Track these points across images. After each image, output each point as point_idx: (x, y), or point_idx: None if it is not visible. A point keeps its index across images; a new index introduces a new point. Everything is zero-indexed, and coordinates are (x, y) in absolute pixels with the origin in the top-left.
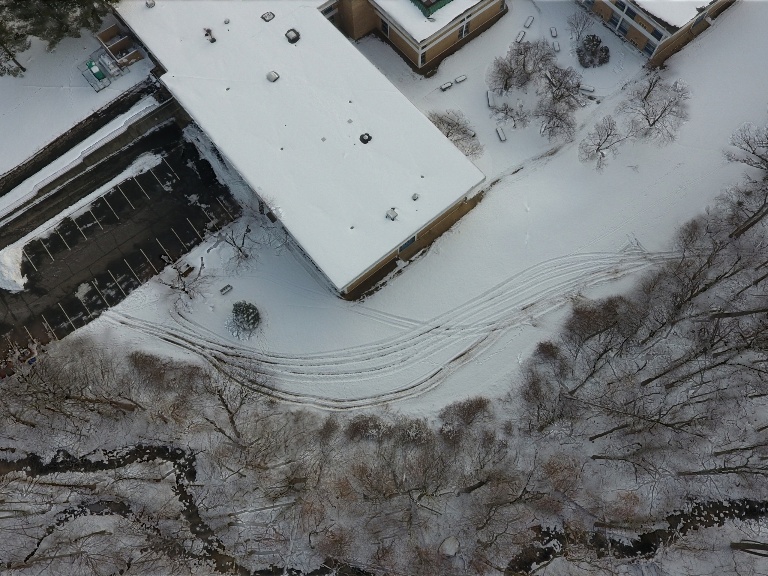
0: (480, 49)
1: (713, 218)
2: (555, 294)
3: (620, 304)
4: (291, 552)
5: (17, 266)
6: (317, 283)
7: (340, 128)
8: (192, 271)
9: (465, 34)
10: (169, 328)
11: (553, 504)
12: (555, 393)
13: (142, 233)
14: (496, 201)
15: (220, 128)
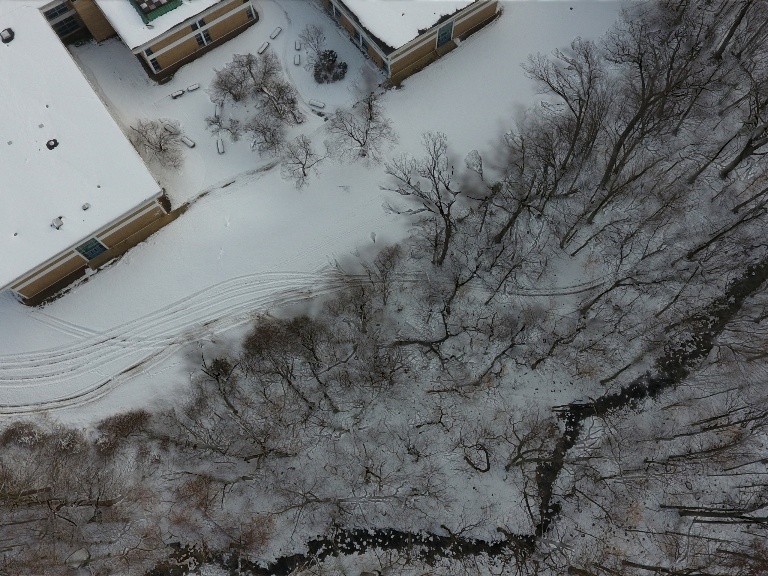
0: (220, 58)
1: (415, 244)
2: (241, 311)
3: (304, 325)
4: None
5: None
6: None
7: (29, 132)
8: None
9: (208, 42)
10: None
11: (189, 522)
12: (217, 411)
13: None
14: (199, 214)
15: None
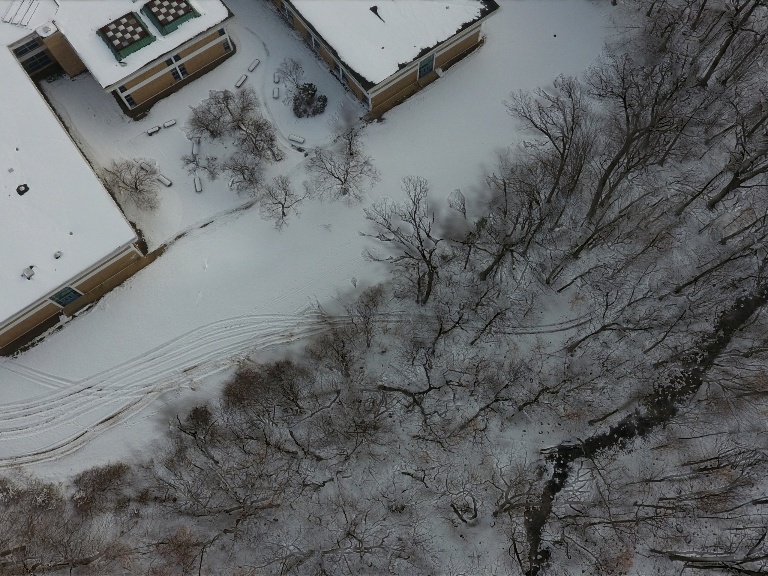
0: (197, 92)
1: (398, 283)
2: (221, 357)
3: (286, 370)
4: None
5: None
6: None
7: None
8: None
9: (185, 75)
10: None
11: None
12: (197, 462)
13: None
14: (176, 256)
15: None
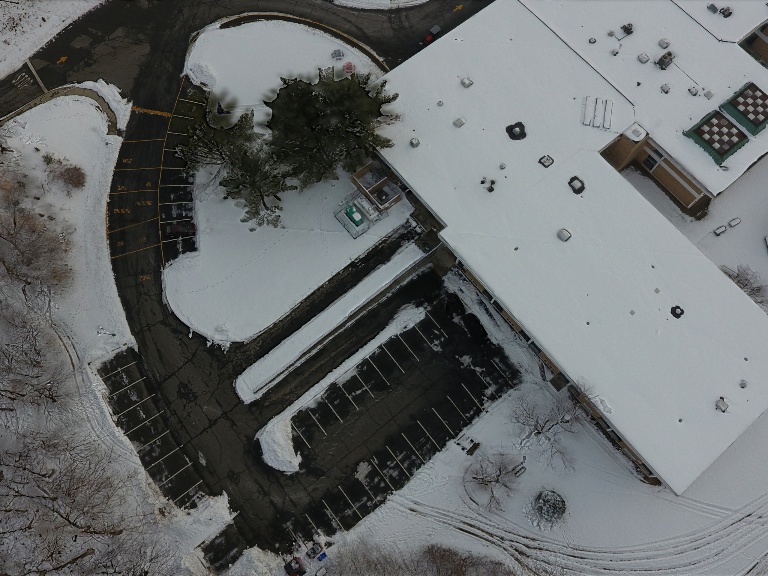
0: (750, 187)
1: None
2: None
3: None
4: None
5: (290, 443)
6: (617, 464)
7: (648, 299)
8: (478, 448)
9: None
10: (463, 516)
11: None
12: None
13: (416, 402)
14: None
15: (516, 297)
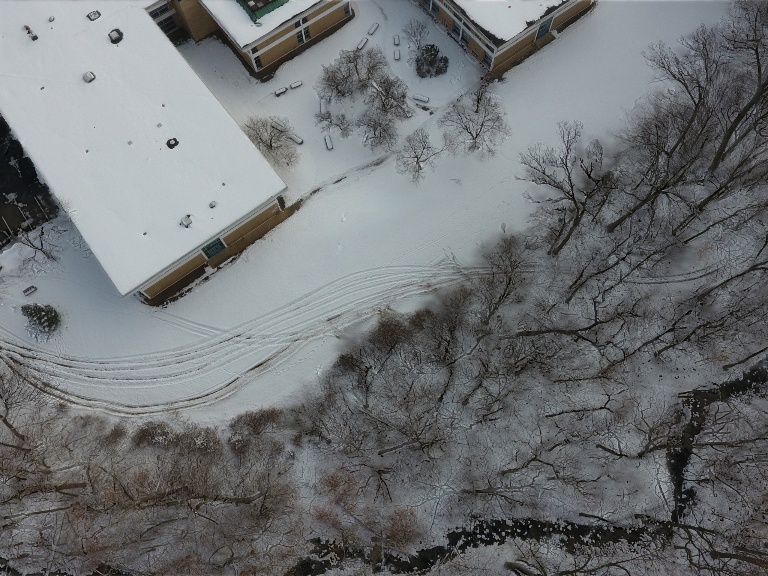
0: (320, 55)
1: (531, 235)
2: (363, 306)
3: (427, 318)
4: (53, 557)
5: None
6: None
7: (148, 132)
8: None
9: (307, 39)
10: None
11: (330, 517)
12: None
13: None
14: (313, 210)
15: (28, 128)
